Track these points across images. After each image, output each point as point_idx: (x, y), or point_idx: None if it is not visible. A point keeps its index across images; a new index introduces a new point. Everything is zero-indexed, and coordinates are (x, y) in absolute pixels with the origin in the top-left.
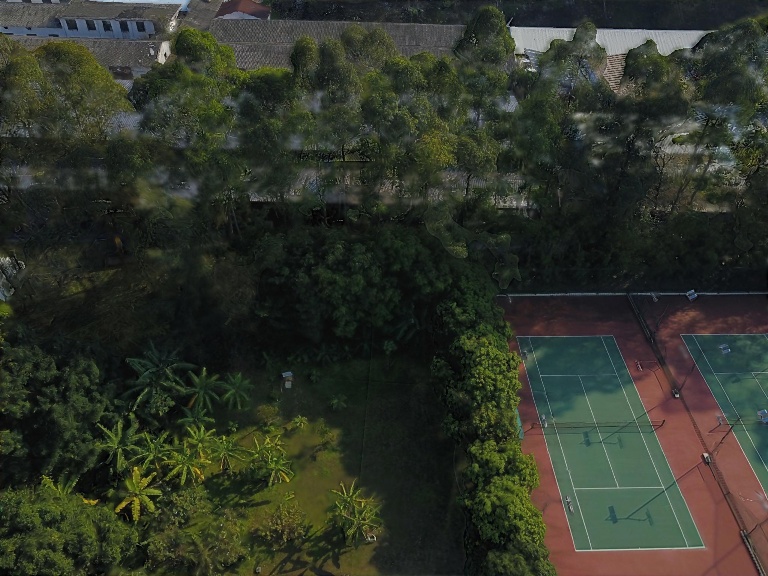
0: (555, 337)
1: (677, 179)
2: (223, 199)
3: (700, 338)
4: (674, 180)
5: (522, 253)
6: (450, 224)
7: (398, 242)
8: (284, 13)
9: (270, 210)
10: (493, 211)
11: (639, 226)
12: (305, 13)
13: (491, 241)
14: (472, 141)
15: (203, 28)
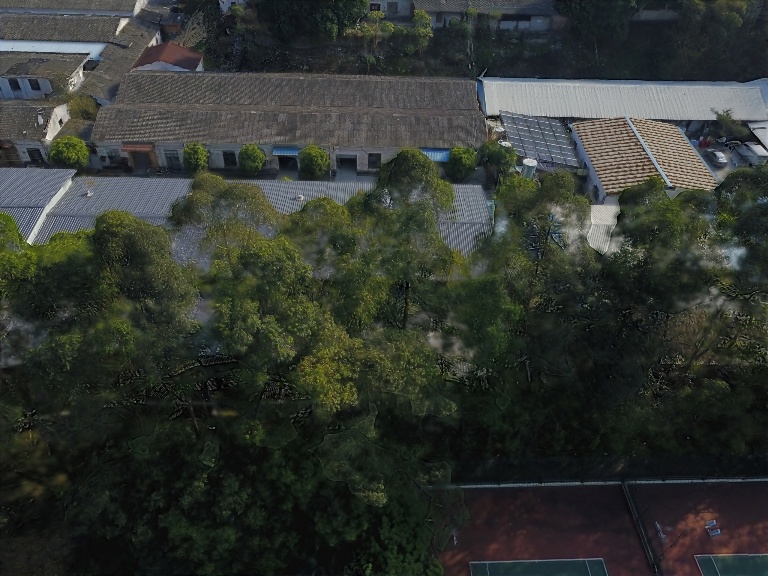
0: (523, 562)
1: (689, 333)
2: (18, 426)
3: (721, 562)
4: (685, 333)
5: (480, 434)
6: (360, 456)
7: (287, 475)
8: (219, 59)
9: (109, 415)
10: (439, 382)
11: (638, 403)
12: (243, 61)
13: (421, 479)
14: (383, 357)
15: (115, 83)
